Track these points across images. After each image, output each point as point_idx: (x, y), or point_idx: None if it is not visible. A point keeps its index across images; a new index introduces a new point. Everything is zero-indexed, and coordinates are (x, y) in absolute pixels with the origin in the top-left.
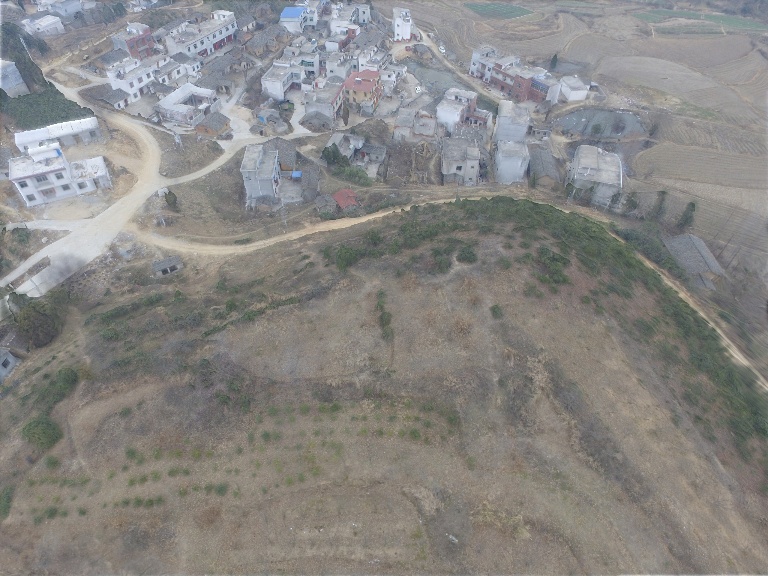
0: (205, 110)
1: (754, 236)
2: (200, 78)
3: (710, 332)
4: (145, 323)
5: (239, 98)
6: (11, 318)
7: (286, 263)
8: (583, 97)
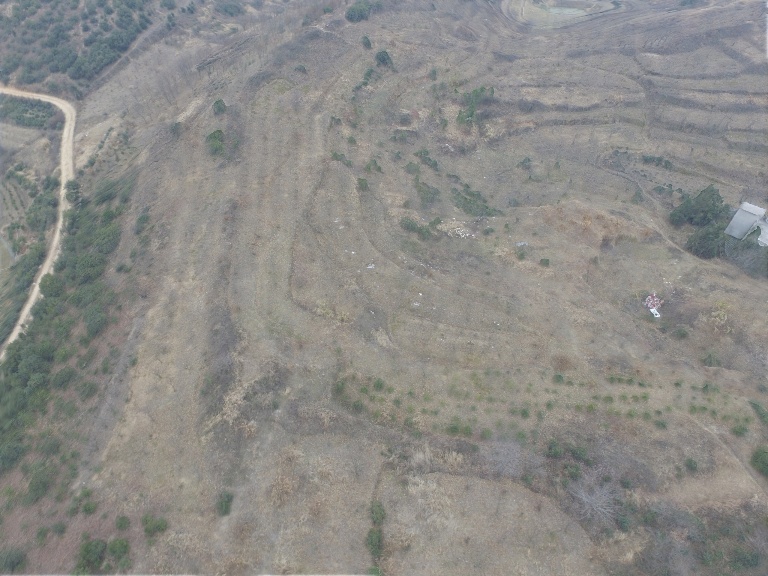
0: None
1: None
2: None
3: None
4: None
5: None
6: None
7: None
8: None
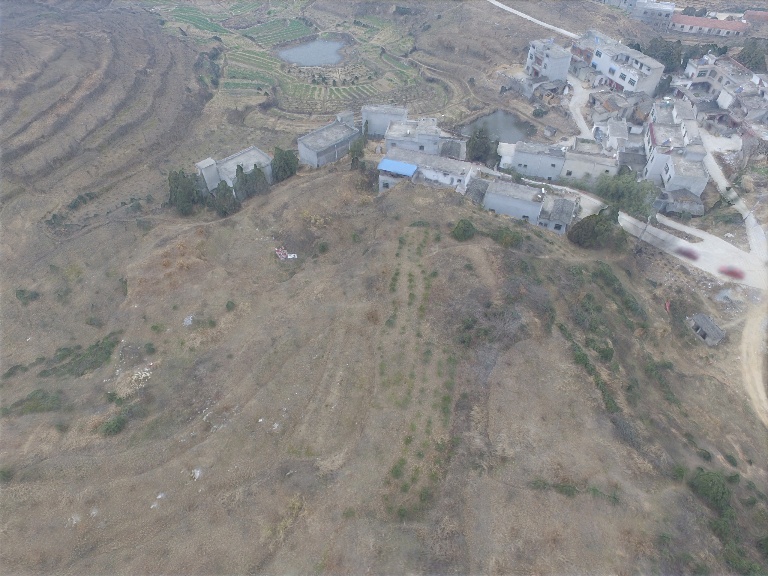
0: None
1: None
2: None
3: None
4: (589, 293)
5: None
6: None
7: (718, 437)
8: None
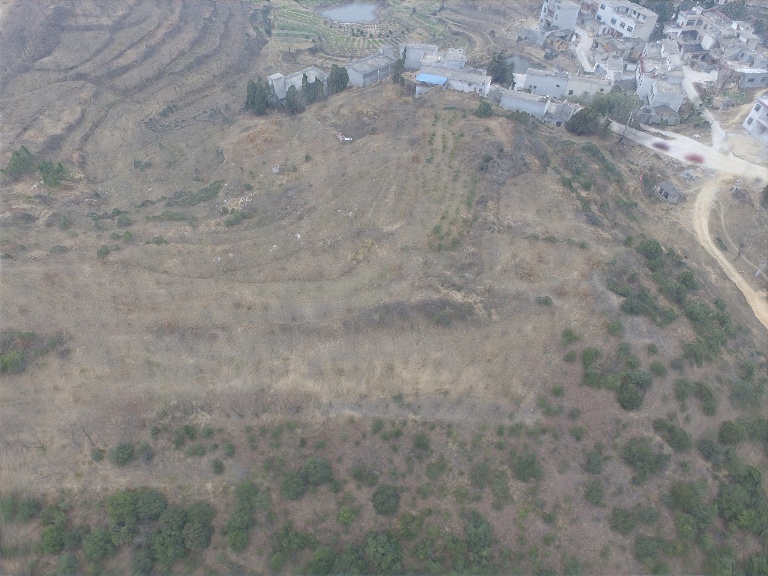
0: None
1: None
2: None
3: None
4: None
5: None
6: None
7: (665, 242)
8: None
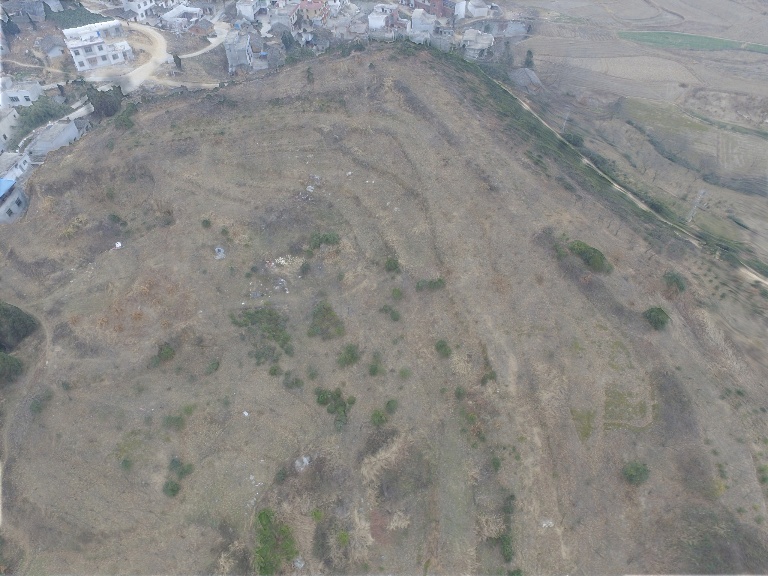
0: (195, 22)
1: (583, 81)
2: (189, 4)
3: (512, 98)
4: None
5: (220, 17)
6: (83, 117)
7: None
8: (485, 14)
